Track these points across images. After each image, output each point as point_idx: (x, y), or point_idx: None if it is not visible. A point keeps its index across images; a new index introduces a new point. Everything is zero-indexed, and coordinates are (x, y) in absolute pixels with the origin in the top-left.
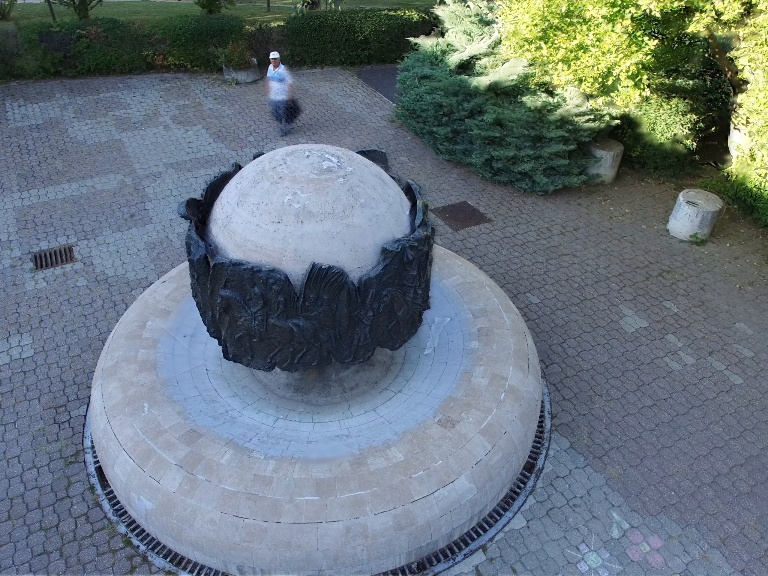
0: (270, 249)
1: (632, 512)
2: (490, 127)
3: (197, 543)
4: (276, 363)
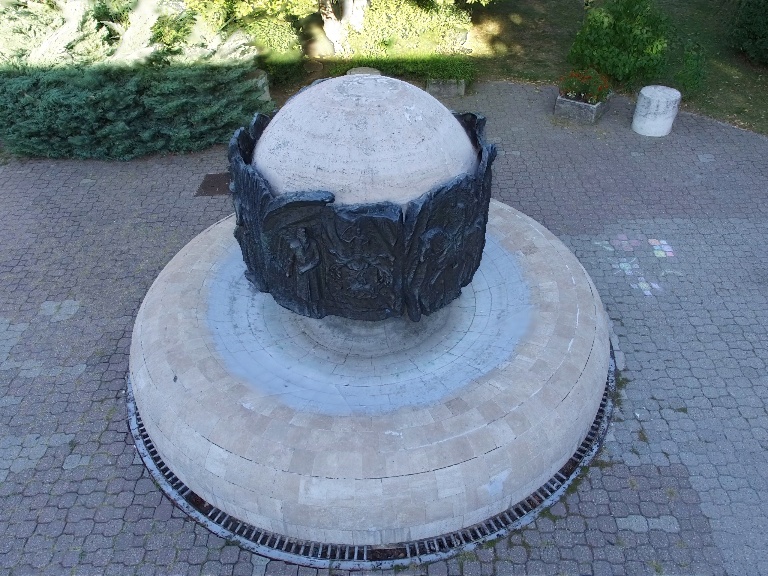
0: (436, 167)
1: (598, 236)
2: (167, 98)
3: (556, 454)
4: (464, 281)
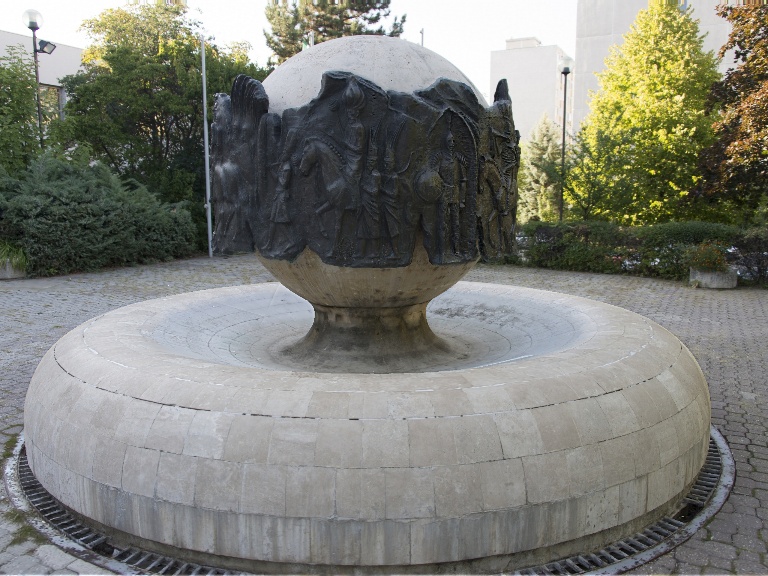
0: None
1: None
2: None
3: None
4: None
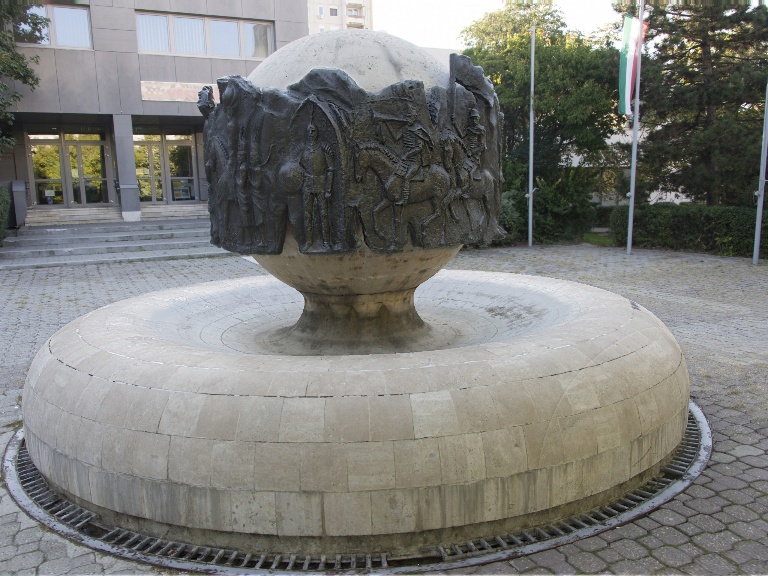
0: None
1: None
2: None
3: None
4: None
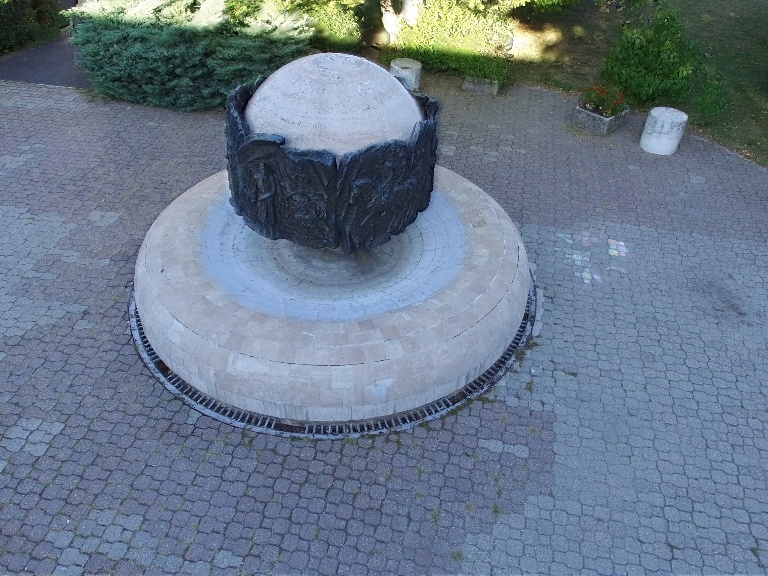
0: (374, 131)
1: (564, 229)
2: (227, 63)
3: (439, 378)
4: (394, 230)
